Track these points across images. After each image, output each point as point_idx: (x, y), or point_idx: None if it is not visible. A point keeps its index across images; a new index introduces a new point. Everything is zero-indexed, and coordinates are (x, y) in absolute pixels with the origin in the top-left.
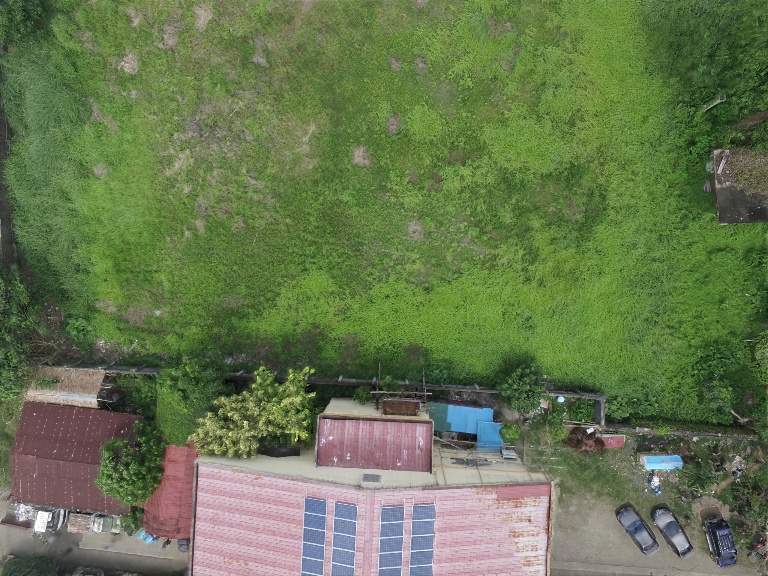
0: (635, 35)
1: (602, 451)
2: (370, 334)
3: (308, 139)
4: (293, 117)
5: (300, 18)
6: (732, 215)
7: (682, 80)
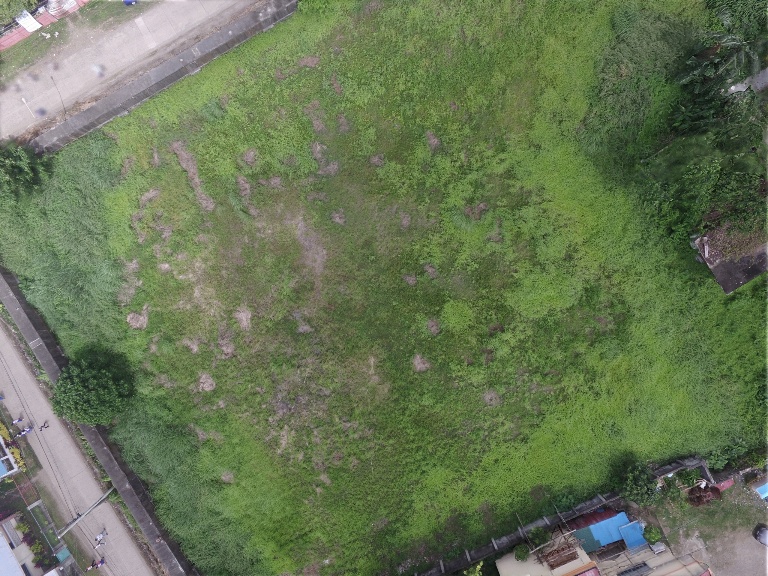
0: (583, 167)
1: (720, 495)
2: (498, 497)
3: (373, 370)
4: (353, 360)
5: (319, 280)
6: (733, 283)
7: (637, 183)
